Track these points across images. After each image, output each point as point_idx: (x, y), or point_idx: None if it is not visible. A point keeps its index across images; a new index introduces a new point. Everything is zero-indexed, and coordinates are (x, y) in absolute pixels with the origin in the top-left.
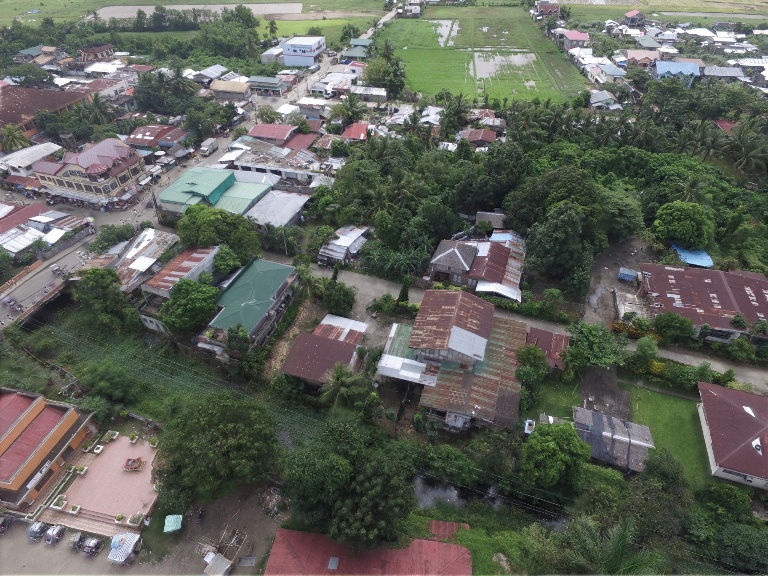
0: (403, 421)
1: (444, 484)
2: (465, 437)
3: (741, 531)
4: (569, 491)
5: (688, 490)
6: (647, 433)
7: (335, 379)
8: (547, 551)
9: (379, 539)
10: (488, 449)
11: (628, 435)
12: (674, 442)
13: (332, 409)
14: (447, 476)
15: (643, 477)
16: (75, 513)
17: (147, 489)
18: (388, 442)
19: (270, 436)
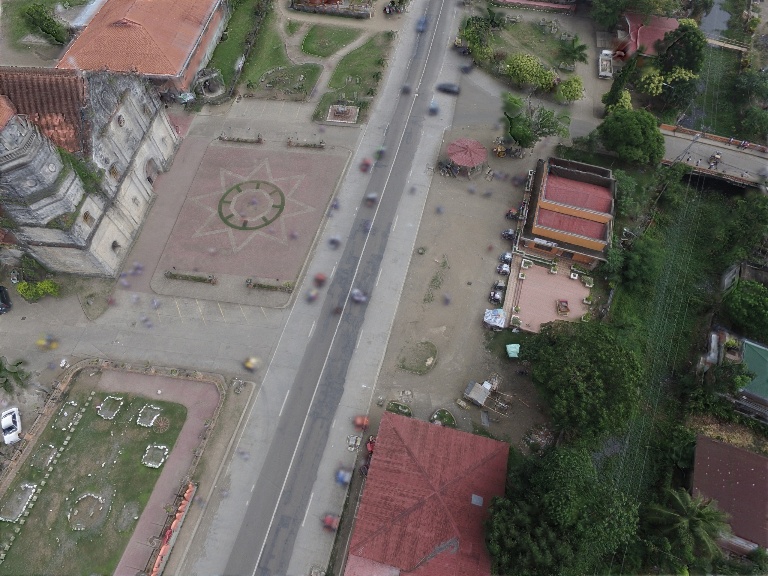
0: None
1: None
2: None
3: None
4: None
5: None
6: None
7: (698, 511)
8: None
9: None
10: None
11: None
12: None
13: (658, 507)
14: None
15: None
16: (519, 277)
17: None
18: None
19: (600, 427)
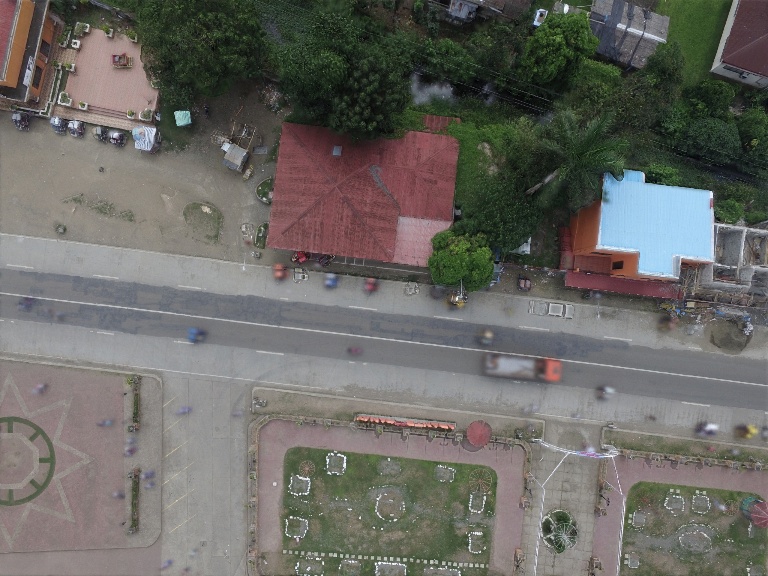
0: (402, 11)
1: (441, 81)
2: (468, 30)
3: (708, 124)
4: (562, 88)
5: (679, 86)
6: (665, 25)
7: None
8: (528, 140)
9: (377, 131)
10: (491, 44)
11: (644, 27)
12: (689, 36)
13: None
14: (444, 73)
15: (640, 73)
16: (85, 110)
17: (145, 86)
18: (385, 36)
19: (257, 28)
